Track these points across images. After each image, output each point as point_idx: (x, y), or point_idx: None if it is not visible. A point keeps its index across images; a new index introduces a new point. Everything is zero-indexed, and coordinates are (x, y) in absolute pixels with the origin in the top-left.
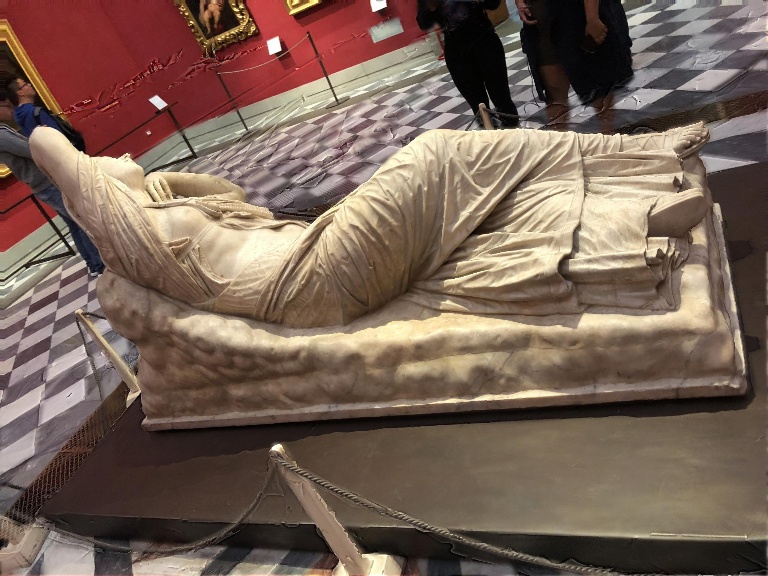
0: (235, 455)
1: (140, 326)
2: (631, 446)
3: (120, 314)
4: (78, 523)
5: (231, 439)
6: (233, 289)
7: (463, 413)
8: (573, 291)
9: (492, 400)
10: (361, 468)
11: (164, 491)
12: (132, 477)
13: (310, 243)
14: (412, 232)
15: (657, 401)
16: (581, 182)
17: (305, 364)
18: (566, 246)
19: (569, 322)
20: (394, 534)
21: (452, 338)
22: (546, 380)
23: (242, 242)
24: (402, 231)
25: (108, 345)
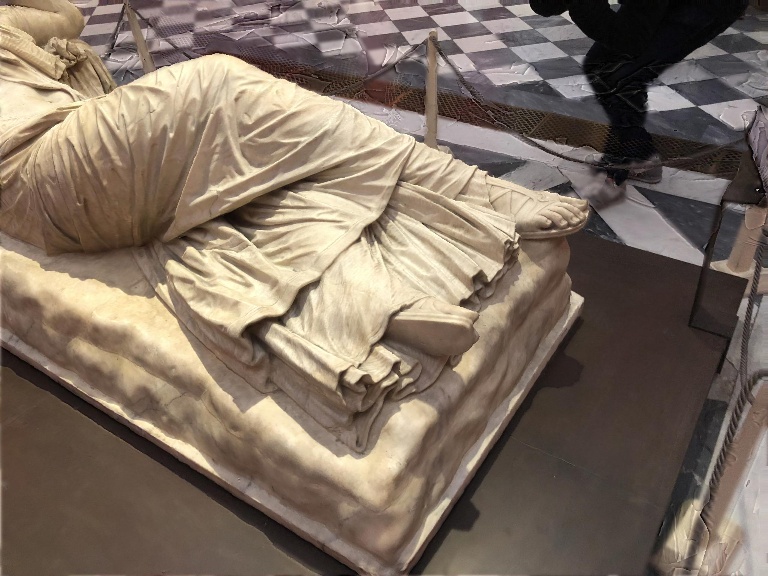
0: None
1: None
2: None
3: None
4: None
5: None
6: None
7: (124, 426)
8: (264, 364)
9: (147, 433)
10: None
11: None
12: None
13: (32, 135)
14: (142, 183)
15: (304, 540)
16: (371, 217)
17: None
18: (283, 302)
19: (243, 399)
20: None
21: (132, 339)
22: (205, 446)
23: None
24: (128, 176)
25: None
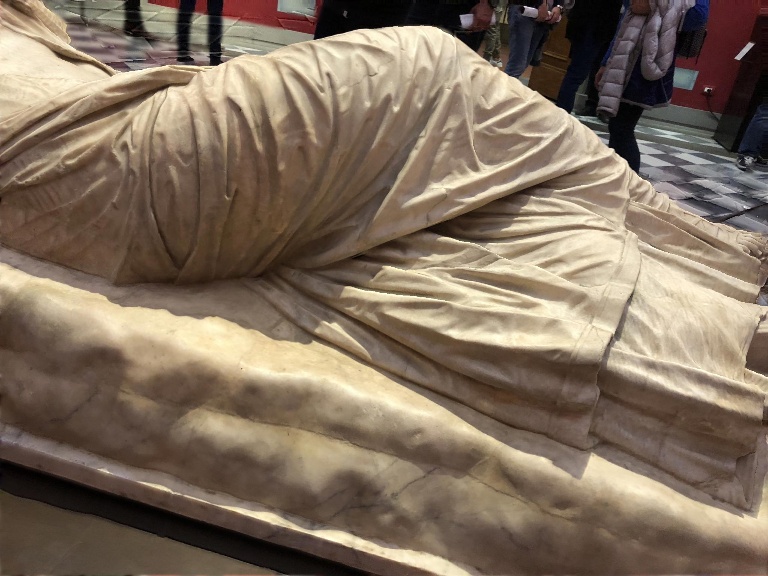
0: None
1: None
2: None
3: None
4: None
5: None
6: None
7: (277, 547)
8: None
9: (350, 547)
10: None
11: None
12: None
13: (124, 98)
14: (334, 172)
15: None
16: None
17: None
18: (607, 321)
19: (566, 460)
20: None
21: (326, 398)
22: (470, 548)
23: None
24: (318, 161)
25: None
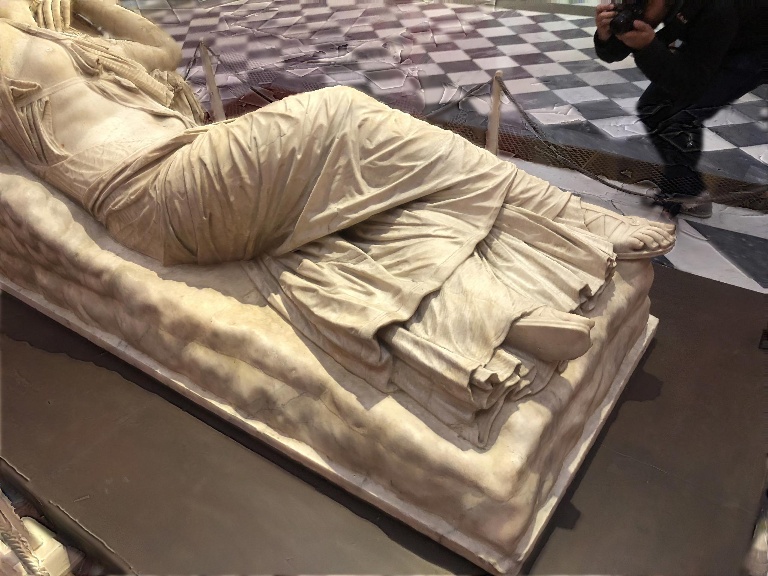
0: (15, 342)
1: None
2: (356, 571)
3: None
4: None
5: (27, 321)
6: (66, 166)
7: (234, 426)
8: (388, 365)
9: (262, 432)
10: (103, 430)
11: None
12: None
13: (160, 156)
14: (266, 200)
15: (419, 533)
16: (481, 235)
17: (105, 287)
18: (407, 309)
19: (366, 398)
20: (72, 529)
21: (251, 343)
22: (321, 443)
23: (105, 116)
24: (254, 193)
25: None
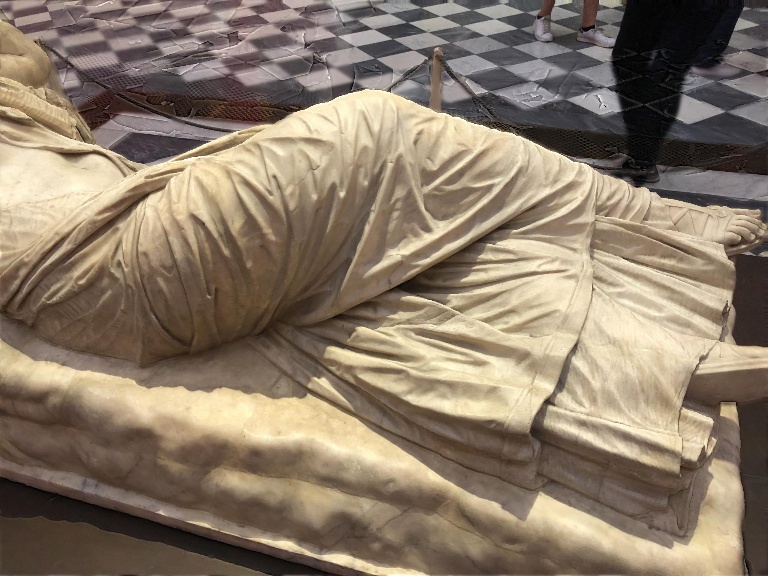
0: None
1: None
2: None
3: None
4: None
5: None
6: None
7: (297, 564)
8: (536, 456)
9: (350, 568)
10: None
11: None
12: None
13: (113, 216)
14: (297, 258)
15: None
16: (587, 260)
17: (54, 415)
18: (548, 377)
19: (514, 503)
20: None
21: (314, 456)
22: (445, 568)
23: None
24: (280, 252)
25: None
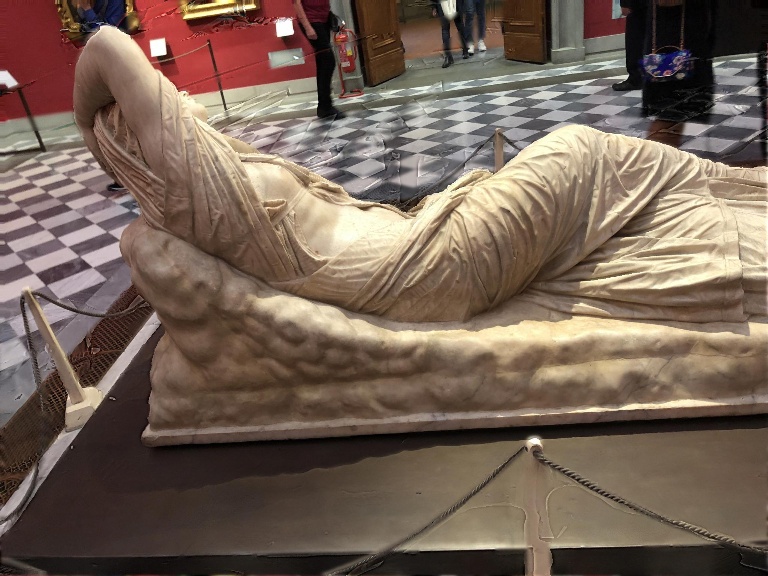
0: (303, 474)
1: (203, 303)
2: None
3: (178, 285)
4: (66, 569)
5: (286, 455)
6: (333, 268)
7: (602, 424)
8: None
9: (643, 409)
10: None
11: (210, 520)
12: (144, 505)
13: (438, 224)
14: (559, 225)
15: None
16: (716, 198)
17: (420, 363)
18: (732, 254)
19: (738, 329)
20: (583, 556)
21: (603, 341)
22: (704, 389)
23: (336, 216)
24: (551, 222)
25: (55, 338)
